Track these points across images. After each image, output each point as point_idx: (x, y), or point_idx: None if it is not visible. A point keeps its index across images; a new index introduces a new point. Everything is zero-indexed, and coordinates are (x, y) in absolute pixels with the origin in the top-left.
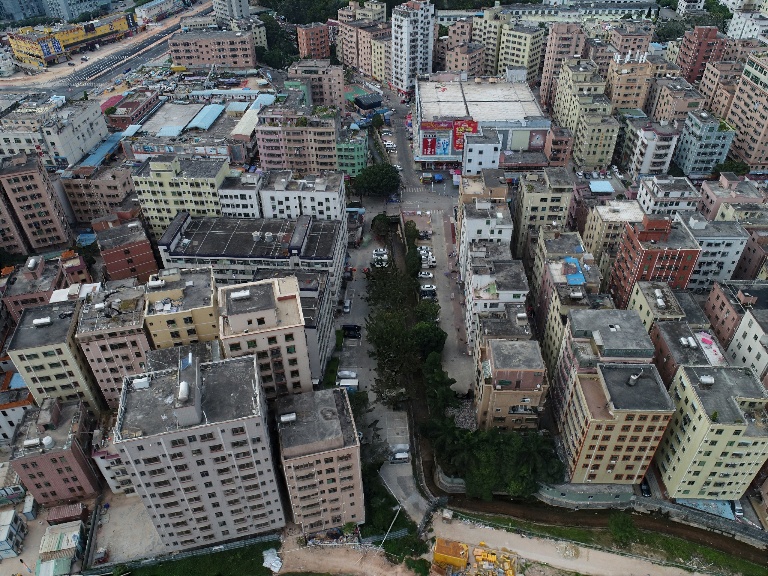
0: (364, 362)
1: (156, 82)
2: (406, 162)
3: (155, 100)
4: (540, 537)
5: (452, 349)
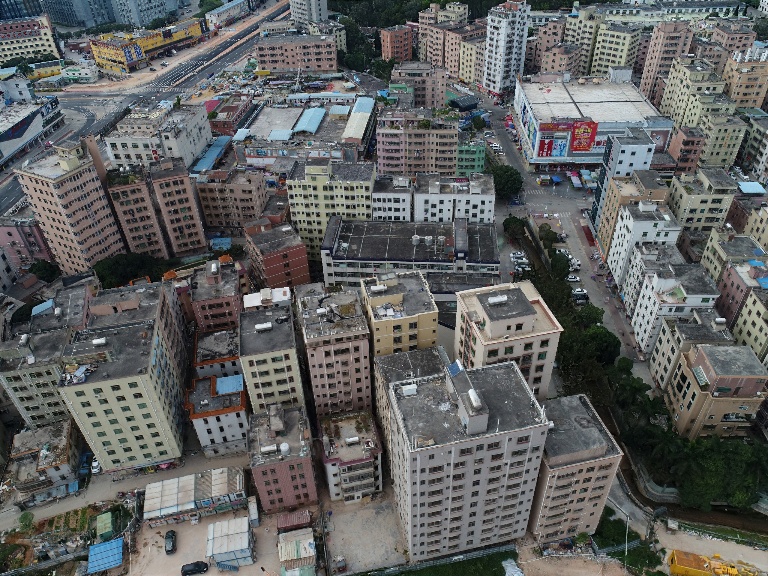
0: None
1: (241, 86)
2: (517, 164)
3: (249, 104)
4: None
5: (621, 354)
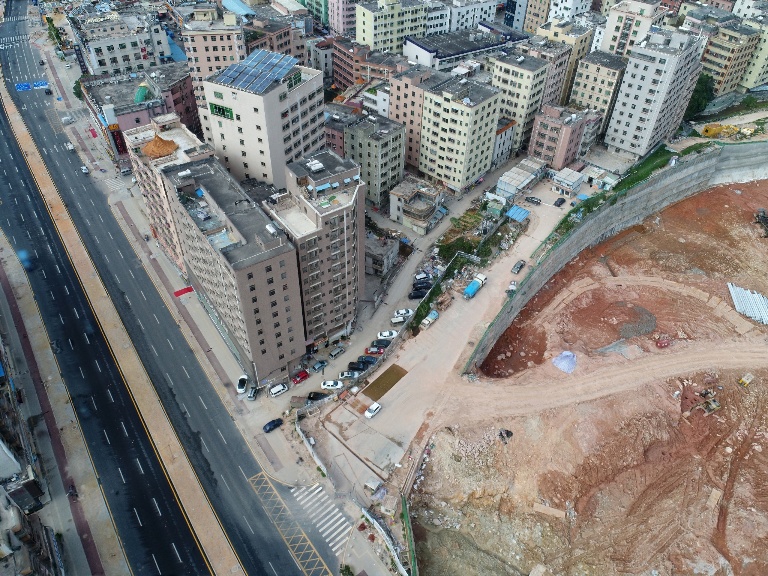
0: None
1: None
2: None
3: None
4: (726, 119)
5: None
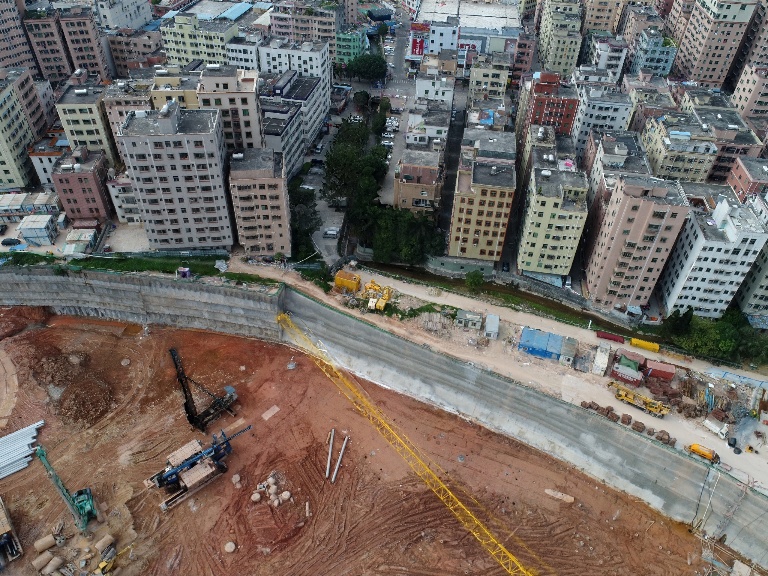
0: (322, 183)
1: None
2: (399, 62)
3: None
4: (416, 283)
5: (393, 181)
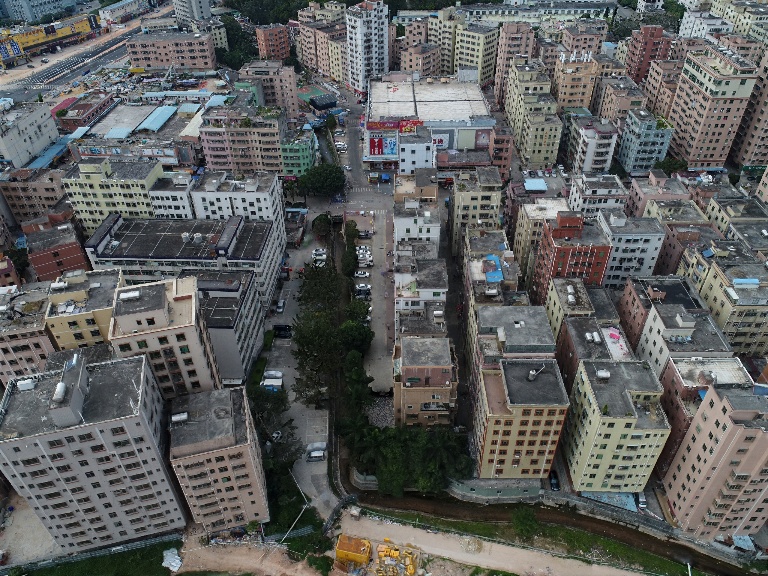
0: (292, 362)
1: (114, 84)
2: (356, 162)
3: (109, 102)
4: (445, 532)
5: (380, 347)
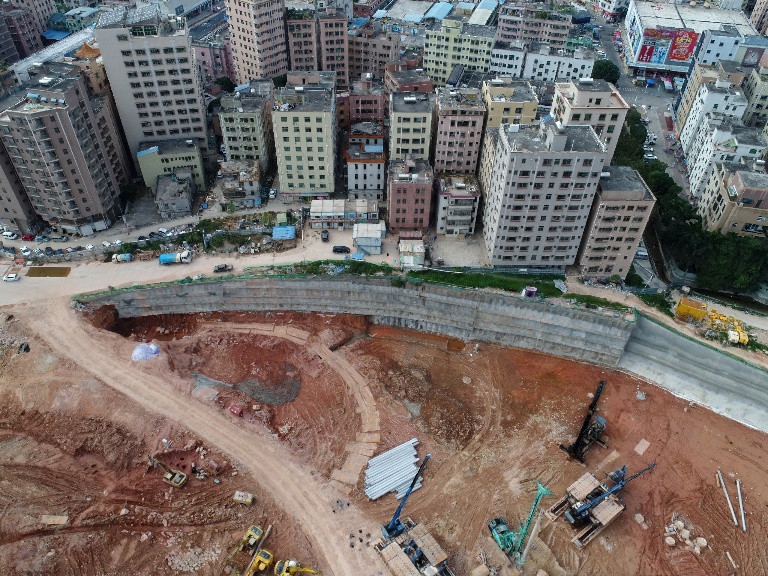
0: None
1: None
2: None
3: None
4: (760, 315)
5: None
